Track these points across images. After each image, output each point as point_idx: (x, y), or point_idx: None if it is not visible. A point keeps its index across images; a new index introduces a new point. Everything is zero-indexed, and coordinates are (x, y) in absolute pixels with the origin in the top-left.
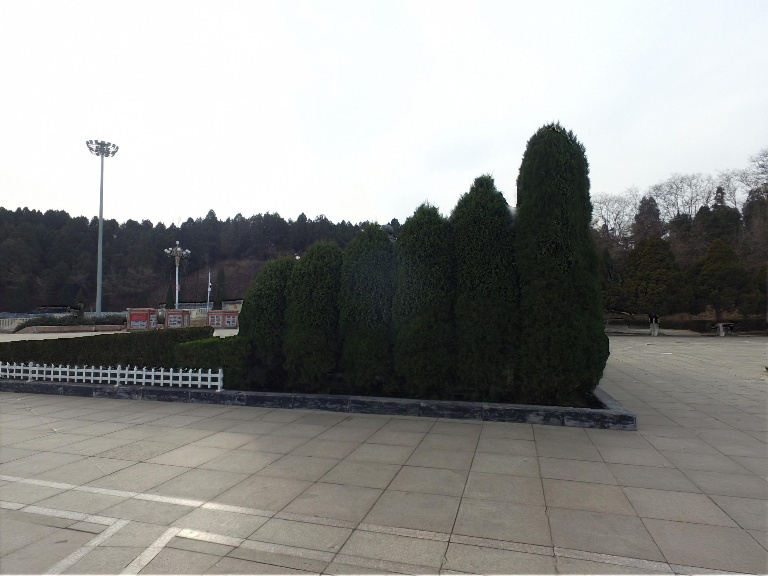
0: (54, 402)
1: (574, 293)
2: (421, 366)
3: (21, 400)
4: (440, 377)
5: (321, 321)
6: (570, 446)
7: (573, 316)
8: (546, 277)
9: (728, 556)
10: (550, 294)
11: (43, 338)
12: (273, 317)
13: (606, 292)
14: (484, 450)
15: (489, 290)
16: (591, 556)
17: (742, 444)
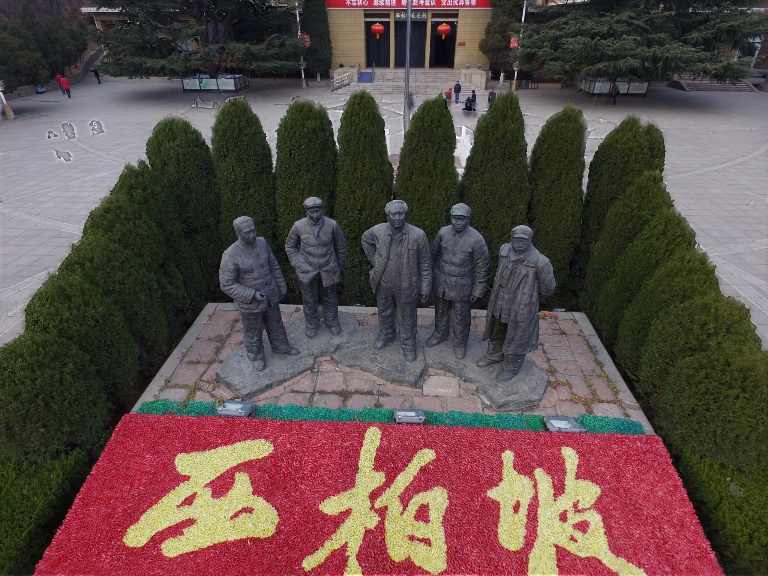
0: None
1: None
2: None
3: None
4: None
5: None
6: None
7: None
8: None
9: None
10: None
11: None
12: None
13: None
14: None
15: None
16: None
17: None
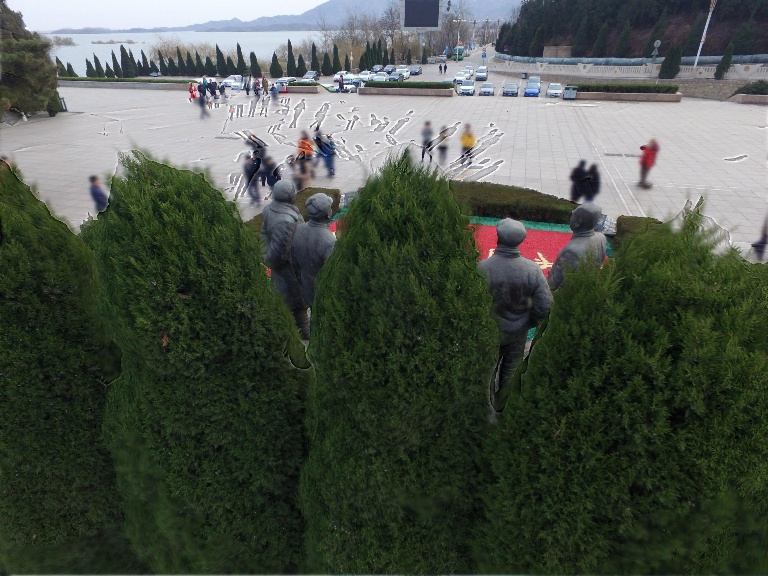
0: None
1: None
2: None
3: None
4: None
5: None
6: None
7: None
8: None
9: None
10: None
11: (680, 123)
12: None
13: None
14: None
15: None
16: None
17: None
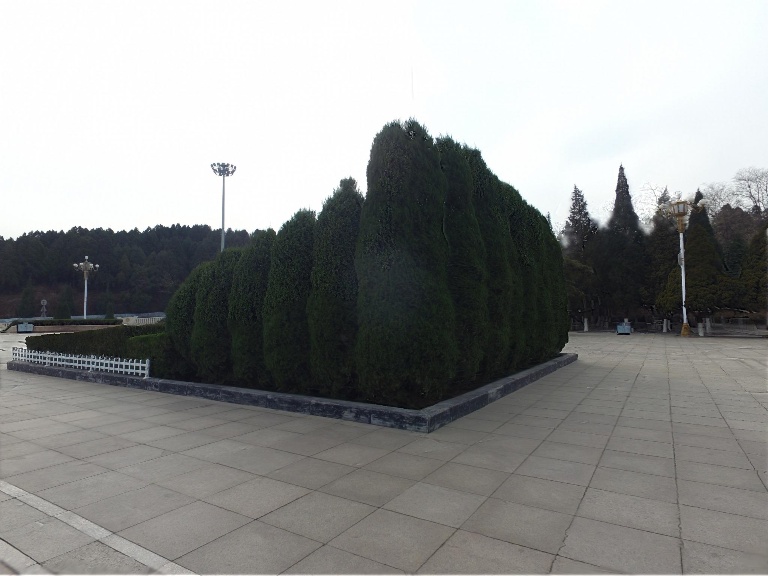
0: (43, 382)
1: (395, 291)
2: (276, 361)
3: (27, 380)
4: (294, 372)
5: (212, 319)
6: (320, 441)
7: (392, 314)
8: (368, 276)
9: (174, 536)
10: (371, 292)
11: None
12: (186, 316)
13: (716, 286)
14: (237, 438)
15: (327, 289)
16: (75, 520)
17: (500, 453)
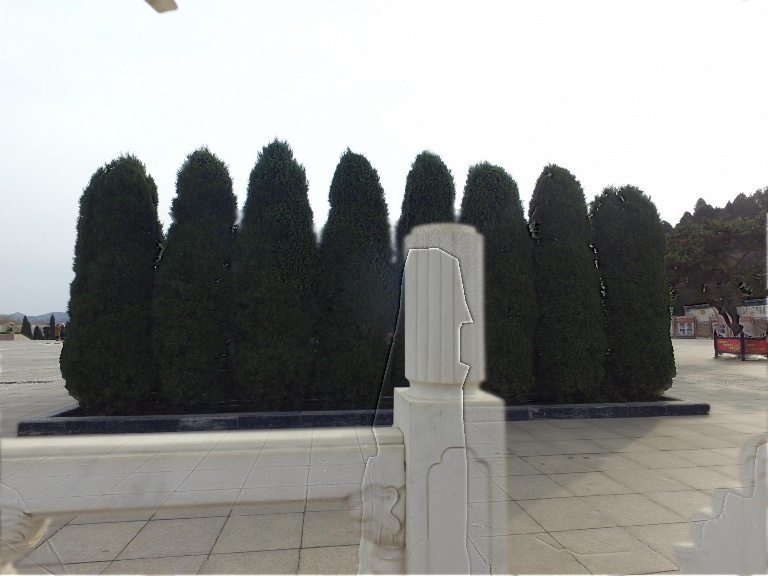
0: None
1: (72, 314)
2: None
3: None
4: None
5: None
6: None
7: None
8: None
9: None
10: None
11: None
12: None
13: None
14: None
15: None
16: None
17: None
